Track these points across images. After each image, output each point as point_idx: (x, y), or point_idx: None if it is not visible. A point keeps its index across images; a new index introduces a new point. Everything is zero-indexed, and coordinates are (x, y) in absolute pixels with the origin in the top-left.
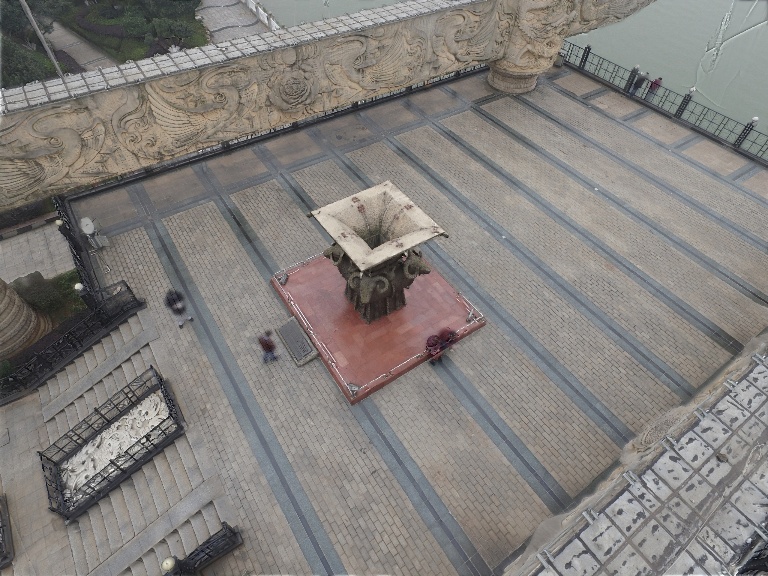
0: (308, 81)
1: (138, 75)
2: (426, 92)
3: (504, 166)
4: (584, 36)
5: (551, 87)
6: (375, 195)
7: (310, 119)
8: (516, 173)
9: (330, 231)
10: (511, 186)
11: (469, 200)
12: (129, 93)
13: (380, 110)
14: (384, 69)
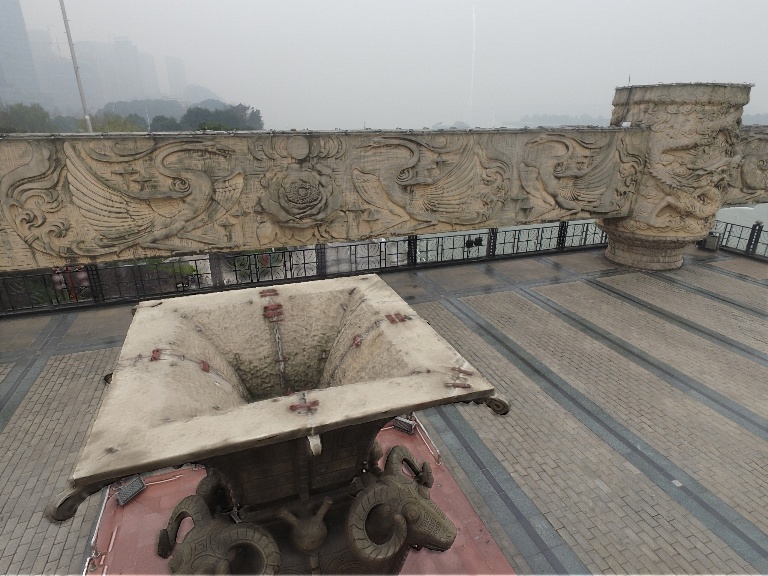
0: (325, 189)
1: (65, 134)
2: (515, 261)
3: (650, 350)
4: (748, 211)
5: (707, 268)
6: (325, 291)
7: (346, 270)
8: (677, 363)
9: (132, 341)
10: (672, 382)
11: (584, 395)
12: (36, 150)
13: (446, 271)
14: (445, 195)
